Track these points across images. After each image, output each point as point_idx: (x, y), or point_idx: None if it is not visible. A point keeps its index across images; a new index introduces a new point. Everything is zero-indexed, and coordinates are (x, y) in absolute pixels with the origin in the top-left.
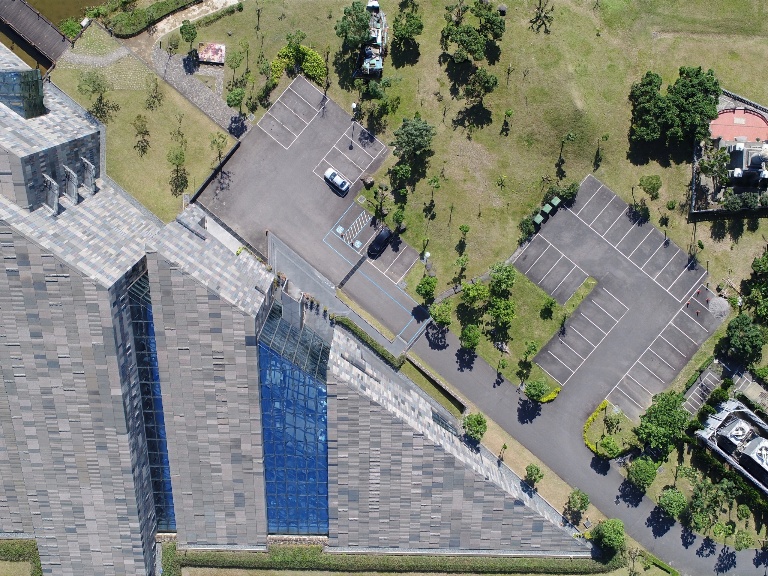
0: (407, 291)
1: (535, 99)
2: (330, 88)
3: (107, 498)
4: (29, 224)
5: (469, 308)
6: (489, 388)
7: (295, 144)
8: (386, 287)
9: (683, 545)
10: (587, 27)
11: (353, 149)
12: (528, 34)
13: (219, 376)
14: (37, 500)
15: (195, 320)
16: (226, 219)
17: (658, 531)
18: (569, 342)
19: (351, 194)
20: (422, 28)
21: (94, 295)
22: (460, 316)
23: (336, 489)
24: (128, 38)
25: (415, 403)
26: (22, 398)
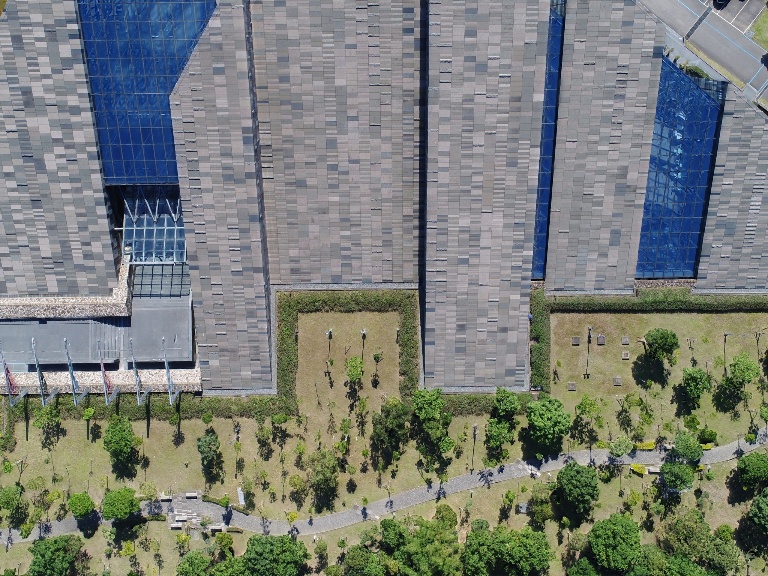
0: (755, 40)
1: None
2: None
3: (506, 222)
4: None
5: None
6: None
7: None
8: (733, 37)
9: None
10: None
11: None
12: None
13: (620, 94)
14: (436, 227)
15: (606, 30)
16: None
17: None
18: None
19: None
20: None
21: None
22: None
23: (714, 222)
24: None
25: None
26: (442, 108)
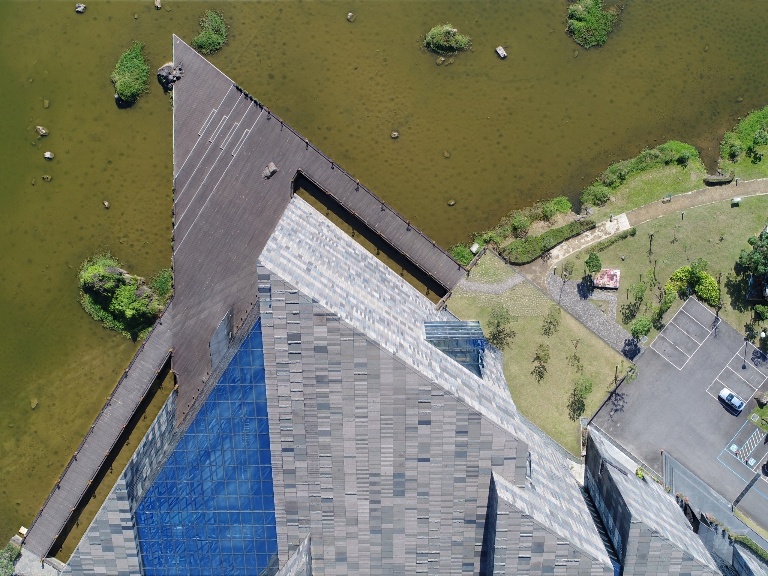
0: None
1: None
2: None
3: None
4: (536, 509)
5: None
6: None
7: (688, 365)
8: None
9: None
10: None
11: (746, 368)
12: None
13: None
14: None
15: None
16: (621, 440)
17: None
18: None
19: (744, 413)
20: None
21: (599, 575)
22: None
23: None
24: (522, 265)
25: None
26: None
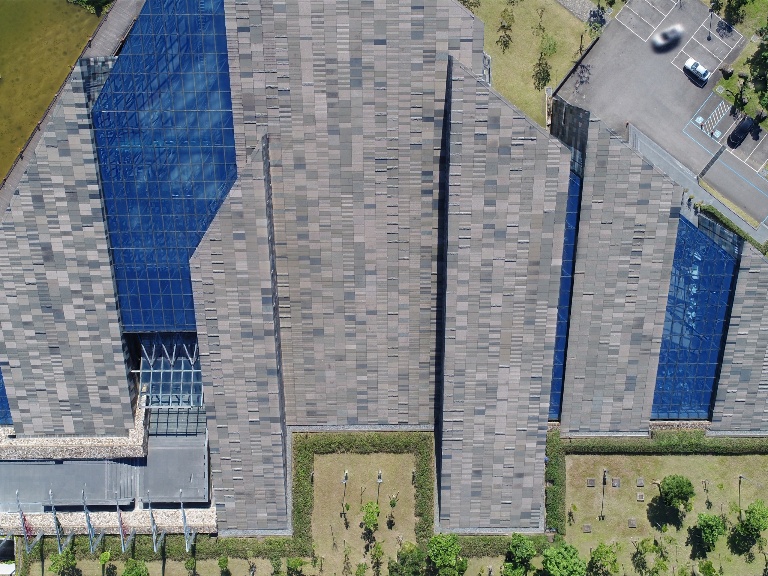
0: None
1: None
2: None
3: (523, 377)
4: None
5: None
6: None
7: (653, 36)
8: (747, 175)
9: None
10: None
11: (711, 40)
12: None
13: (636, 251)
14: (453, 381)
15: (624, 192)
16: None
17: None
18: None
19: (710, 84)
20: None
21: (556, 159)
22: None
23: (729, 369)
24: None
25: None
26: (461, 271)
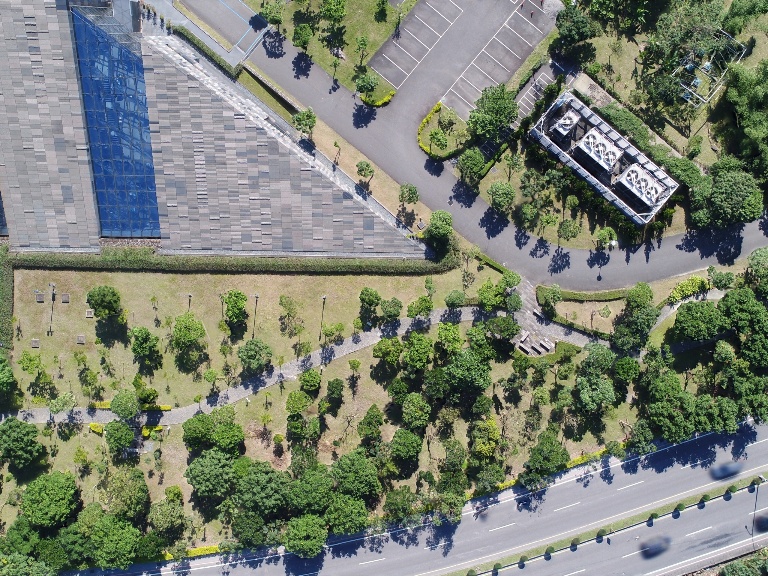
0: (245, 1)
1: None
2: None
3: None
4: None
5: (305, 15)
6: (325, 94)
7: None
8: None
9: (517, 246)
10: None
11: None
12: None
13: (33, 46)
14: None
15: None
16: None
17: (491, 232)
18: (403, 45)
19: None
20: None
21: None
22: (297, 24)
23: (163, 180)
24: None
25: (248, 104)
26: None
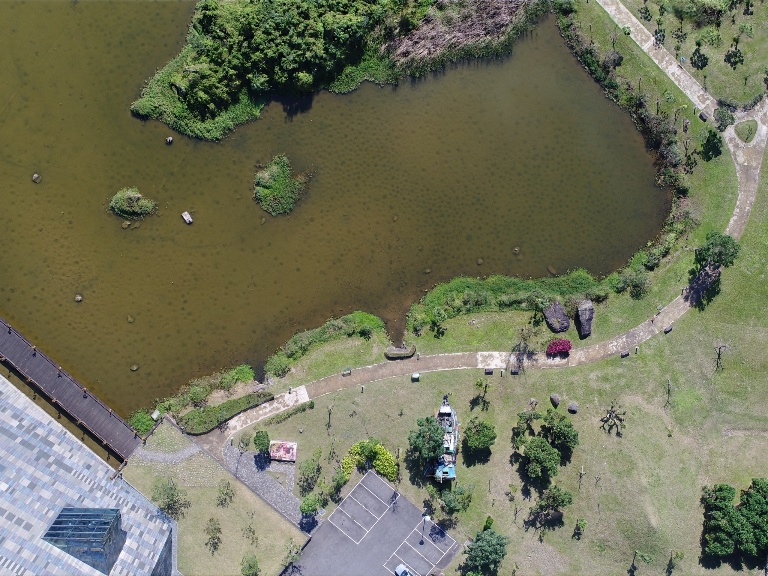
0: None
1: (608, 507)
2: (401, 484)
3: None
4: None
5: None
6: None
7: (366, 539)
8: None
9: None
10: (658, 428)
11: (424, 544)
12: (599, 435)
13: None
14: None
15: None
16: None
17: None
18: None
19: None
20: (495, 438)
21: None
22: None
23: None
24: (199, 435)
25: None
26: None
